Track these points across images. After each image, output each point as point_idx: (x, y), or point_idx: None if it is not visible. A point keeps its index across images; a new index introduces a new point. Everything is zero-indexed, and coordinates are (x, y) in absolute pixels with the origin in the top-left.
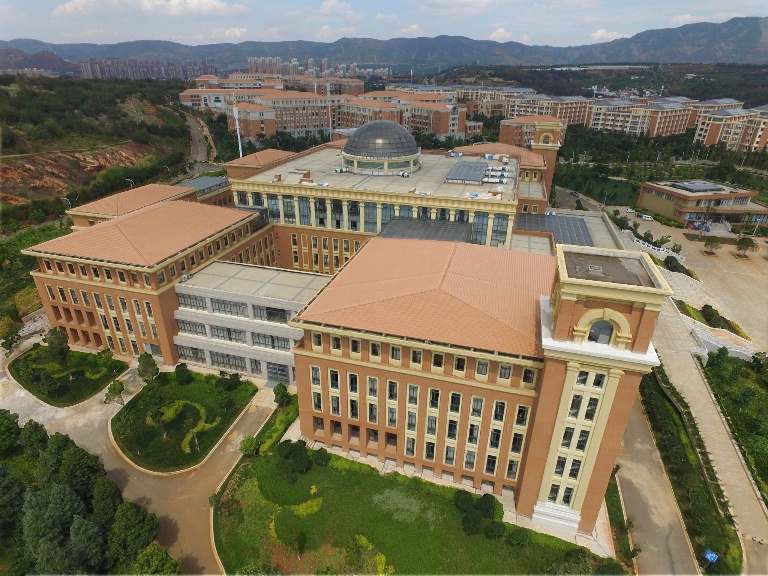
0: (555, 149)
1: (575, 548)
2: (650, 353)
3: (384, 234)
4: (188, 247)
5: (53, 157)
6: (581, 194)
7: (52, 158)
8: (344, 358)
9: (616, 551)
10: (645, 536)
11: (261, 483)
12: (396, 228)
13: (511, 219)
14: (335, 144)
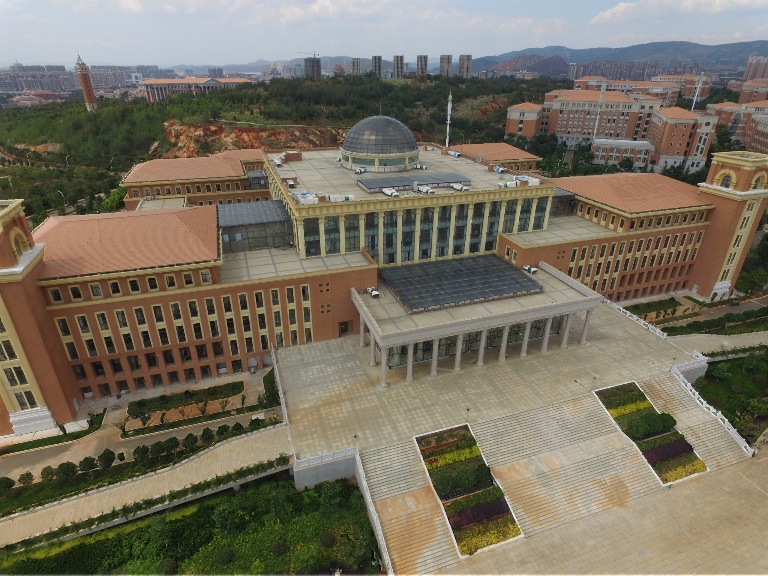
0: (734, 198)
1: None
2: None
3: (228, 205)
4: (160, 181)
5: (323, 130)
6: None
7: (322, 130)
8: None
9: None
10: None
11: None
12: (247, 205)
13: None
14: (468, 145)
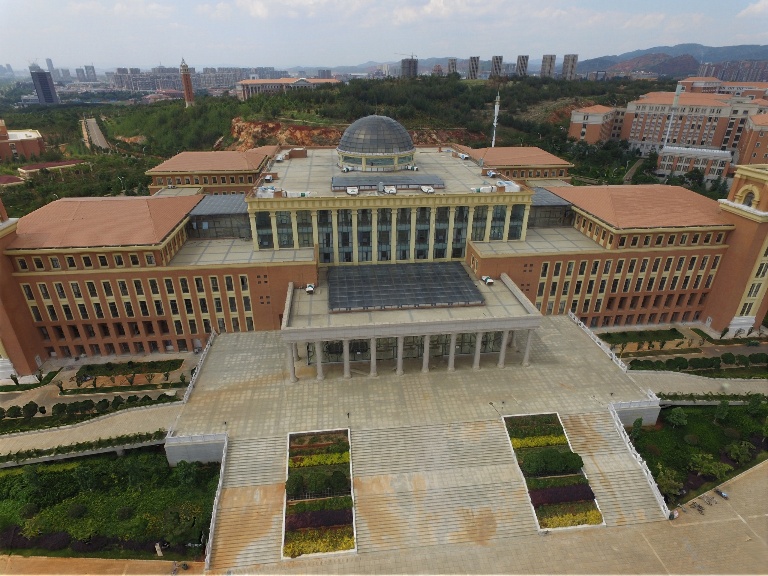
0: (754, 219)
1: None
2: None
3: (215, 196)
4: (180, 171)
5: None
6: None
7: None
8: None
9: None
10: None
11: None
12: None
13: None
14: (495, 148)
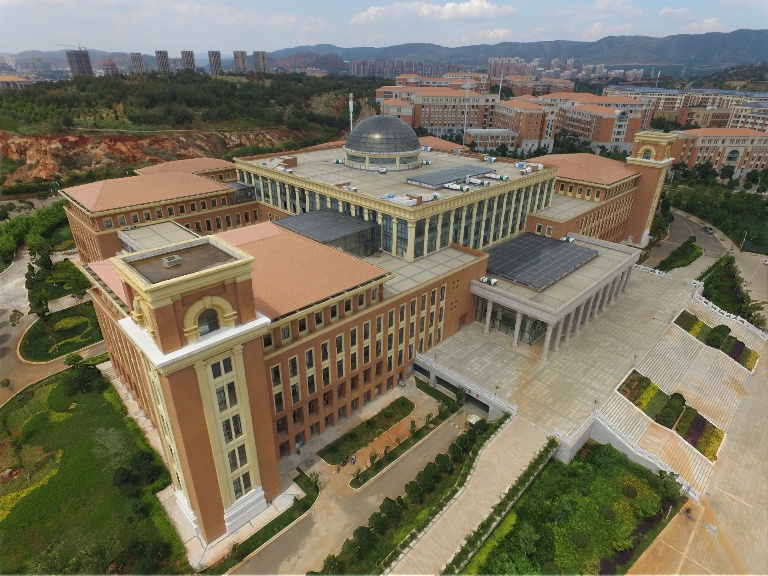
0: (656, 167)
1: (174, 543)
2: (170, 355)
3: (284, 220)
4: (139, 204)
5: (208, 134)
6: (720, 232)
7: (206, 135)
8: (102, 305)
9: (208, 568)
10: (251, 573)
11: (54, 388)
12: (304, 217)
13: (410, 227)
14: None
